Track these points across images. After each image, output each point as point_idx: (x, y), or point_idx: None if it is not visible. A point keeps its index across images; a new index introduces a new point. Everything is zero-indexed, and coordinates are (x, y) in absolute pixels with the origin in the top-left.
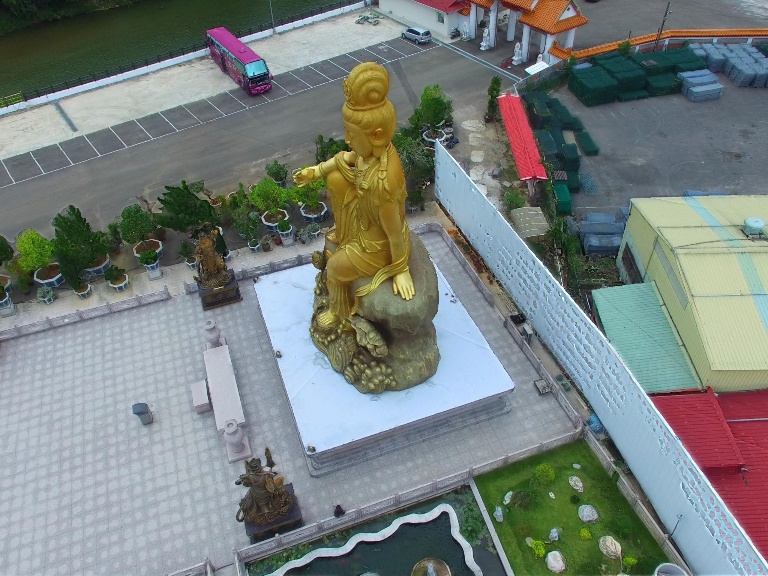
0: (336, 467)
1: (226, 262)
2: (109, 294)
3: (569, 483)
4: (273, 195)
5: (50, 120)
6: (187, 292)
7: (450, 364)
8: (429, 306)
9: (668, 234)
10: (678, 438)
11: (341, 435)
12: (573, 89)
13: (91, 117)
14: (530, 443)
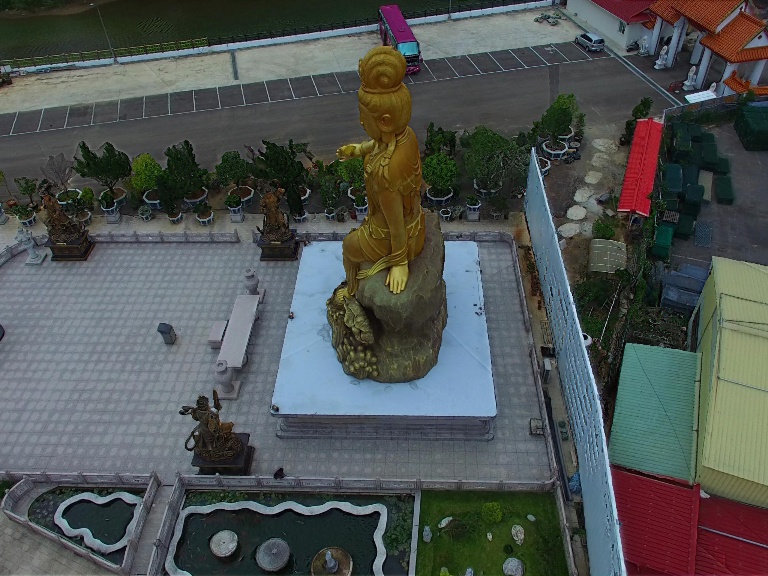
0: (300, 434)
1: (300, 222)
2: (194, 225)
3: (511, 531)
4: (359, 170)
5: (221, 66)
6: (254, 240)
7: (443, 373)
8: (418, 306)
9: (728, 304)
10: (618, 522)
11: (308, 405)
12: (738, 127)
13: (254, 69)
14: (496, 478)
